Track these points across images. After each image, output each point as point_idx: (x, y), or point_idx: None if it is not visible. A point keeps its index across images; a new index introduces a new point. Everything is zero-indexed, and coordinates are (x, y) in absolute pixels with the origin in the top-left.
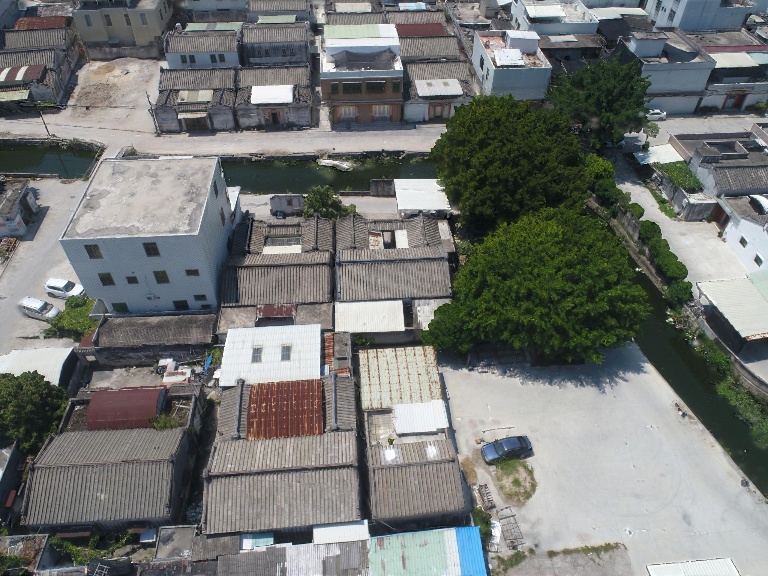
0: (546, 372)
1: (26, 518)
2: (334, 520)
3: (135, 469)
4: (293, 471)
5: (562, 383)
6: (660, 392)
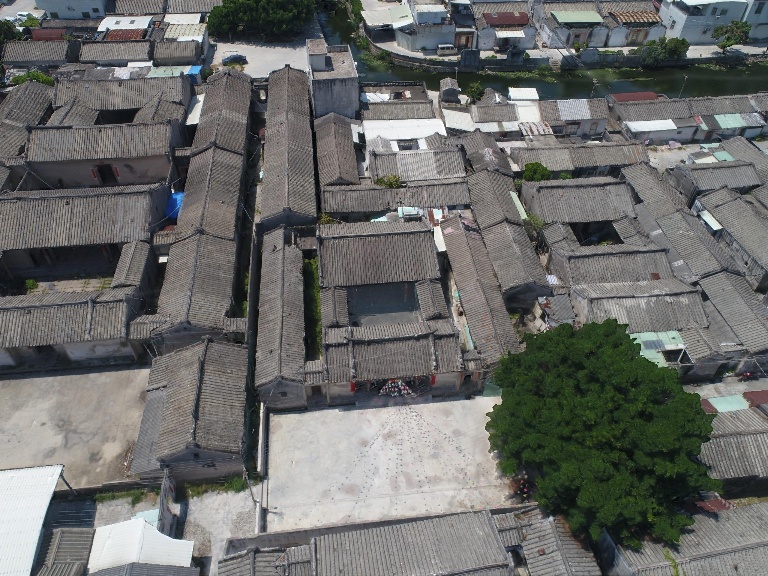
0: (270, 44)
1: (3, 59)
2: (137, 58)
3: (52, 44)
4: (121, 42)
5: (276, 47)
6: None
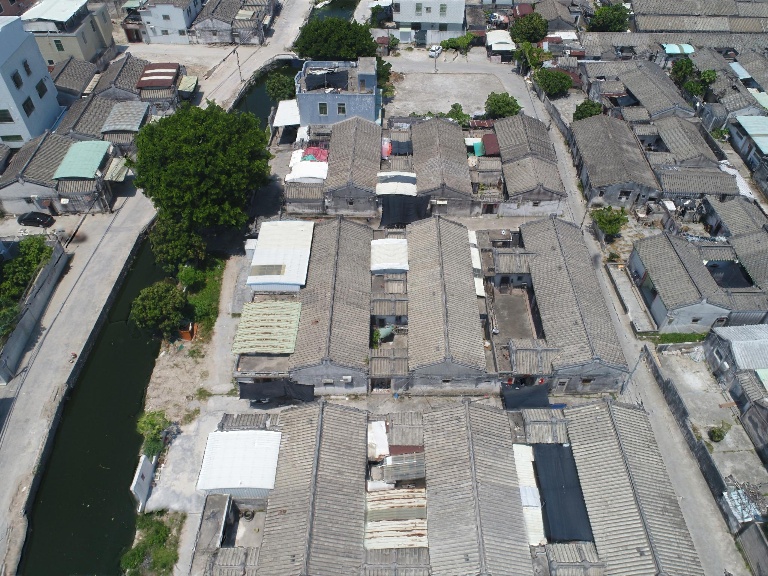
0: None
1: None
2: None
3: (556, 4)
4: None
5: None
6: None
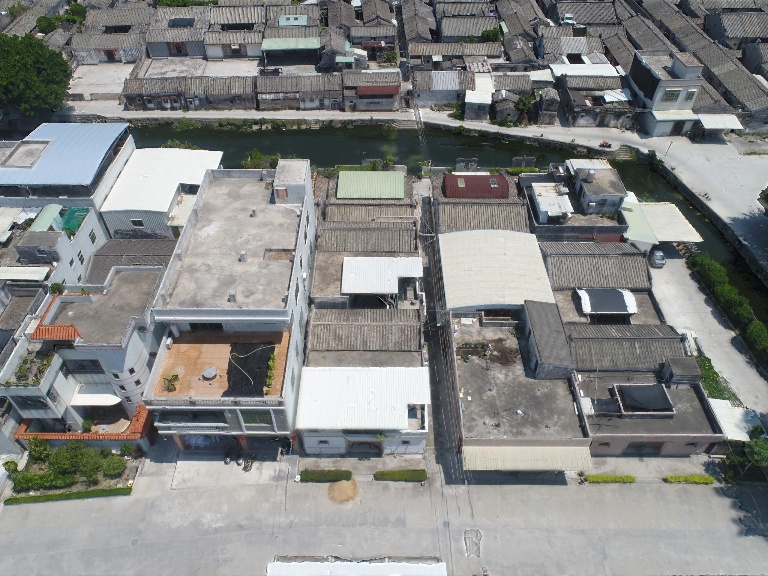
0: None
1: None
2: None
3: None
4: None
5: None
6: (720, 207)
